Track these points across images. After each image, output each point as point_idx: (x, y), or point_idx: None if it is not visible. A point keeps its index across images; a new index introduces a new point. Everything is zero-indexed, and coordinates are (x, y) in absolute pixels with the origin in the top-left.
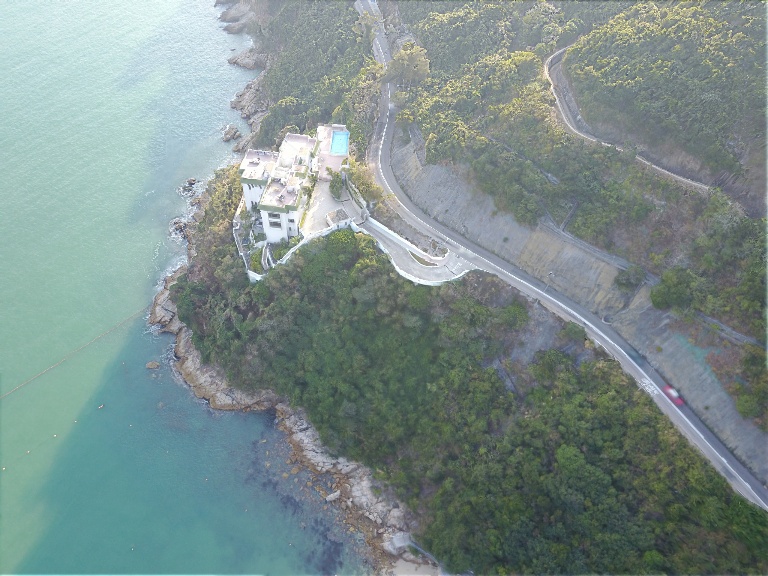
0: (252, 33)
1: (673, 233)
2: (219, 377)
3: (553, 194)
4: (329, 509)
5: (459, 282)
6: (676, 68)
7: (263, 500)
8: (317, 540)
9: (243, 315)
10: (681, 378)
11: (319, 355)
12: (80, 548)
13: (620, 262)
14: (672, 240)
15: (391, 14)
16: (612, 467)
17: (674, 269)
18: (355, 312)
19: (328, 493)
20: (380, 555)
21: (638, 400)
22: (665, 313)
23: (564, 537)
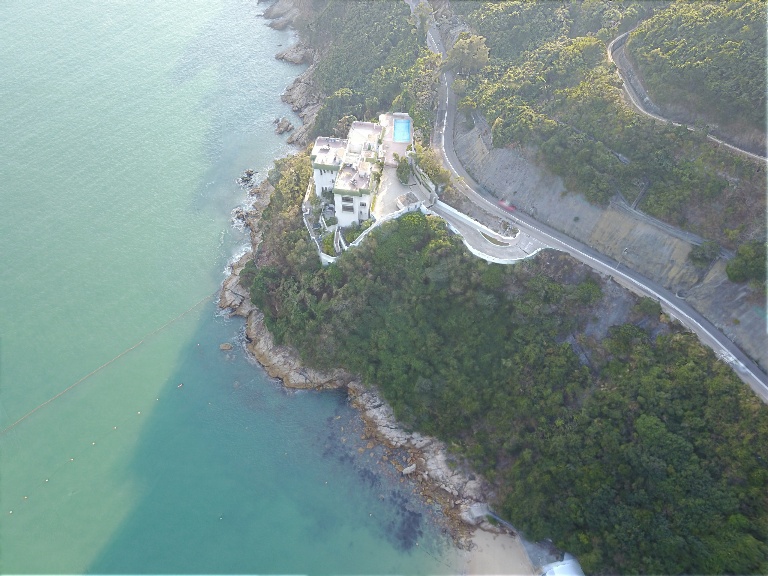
0: (301, 28)
1: (747, 209)
2: (292, 357)
3: (624, 173)
4: (406, 482)
5: (532, 260)
6: (746, 48)
7: (341, 473)
8: (396, 511)
9: (316, 296)
10: (760, 349)
11: (392, 334)
12: (171, 517)
13: (693, 238)
14: (746, 215)
15: (442, 6)
16: (693, 435)
17: (750, 243)
18: (428, 291)
19: (404, 467)
20: (458, 525)
21: (718, 370)
22: (741, 286)
23: (647, 503)
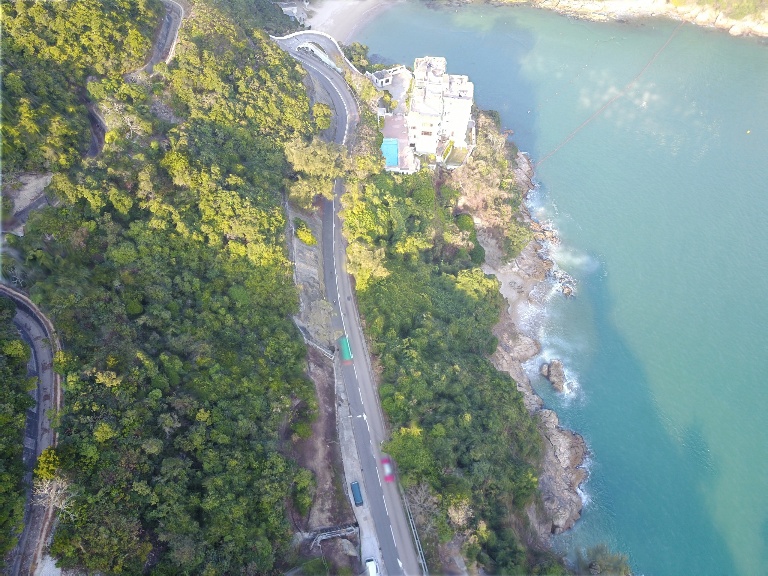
0: None
1: None
2: None
3: None
4: None
5: None
6: None
7: None
8: None
9: None
10: None
11: None
12: (501, 63)
13: None
14: None
15: None
16: None
17: None
18: None
19: None
20: None
21: None
22: None
23: None
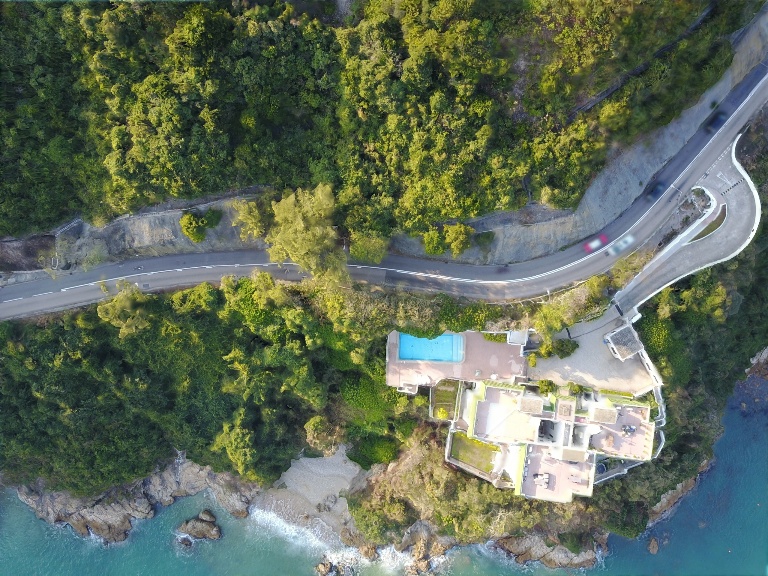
0: None
1: None
2: None
3: None
4: None
5: None
6: None
7: None
8: None
9: None
10: None
11: None
12: None
13: None
14: None
15: (6, 256)
16: None
17: None
18: None
19: None
20: None
21: None
22: None
23: None
